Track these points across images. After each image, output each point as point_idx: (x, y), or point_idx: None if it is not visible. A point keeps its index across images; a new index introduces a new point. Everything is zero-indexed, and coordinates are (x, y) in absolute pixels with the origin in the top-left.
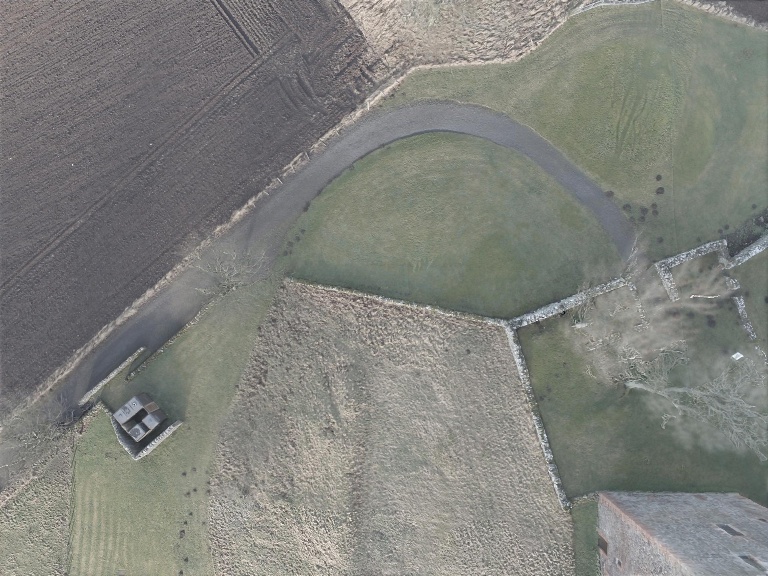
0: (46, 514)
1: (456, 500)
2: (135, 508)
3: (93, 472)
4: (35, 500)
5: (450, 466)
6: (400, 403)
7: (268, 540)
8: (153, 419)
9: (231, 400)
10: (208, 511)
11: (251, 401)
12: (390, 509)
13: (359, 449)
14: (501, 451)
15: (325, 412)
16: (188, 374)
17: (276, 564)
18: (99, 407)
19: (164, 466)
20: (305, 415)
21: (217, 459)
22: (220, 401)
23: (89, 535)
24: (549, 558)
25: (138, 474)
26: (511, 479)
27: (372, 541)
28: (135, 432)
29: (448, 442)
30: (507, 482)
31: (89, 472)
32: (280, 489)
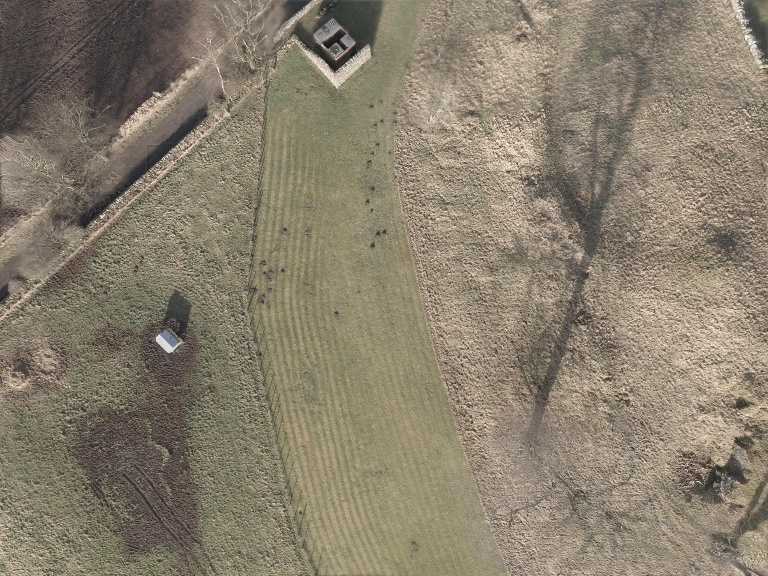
0: (237, 152)
1: (653, 75)
2: (324, 142)
3: (284, 108)
4: (227, 138)
5: (647, 45)
6: (590, 7)
7: (455, 159)
8: (351, 38)
9: (417, 34)
10: (394, 141)
11: (437, 33)
12: (582, 106)
13: (551, 52)
14: (696, 27)
15: (517, 21)
16: (376, 11)
17: (463, 181)
18: (294, 39)
19: (352, 100)
20: (495, 31)
21: (404, 90)
22: (407, 35)
23: (279, 170)
24: (748, 113)
25: (327, 109)
26: (707, 51)
27: (563, 138)
28: (335, 49)
29: (644, 25)
30: (703, 54)
31: (280, 108)
32: (468, 108)
